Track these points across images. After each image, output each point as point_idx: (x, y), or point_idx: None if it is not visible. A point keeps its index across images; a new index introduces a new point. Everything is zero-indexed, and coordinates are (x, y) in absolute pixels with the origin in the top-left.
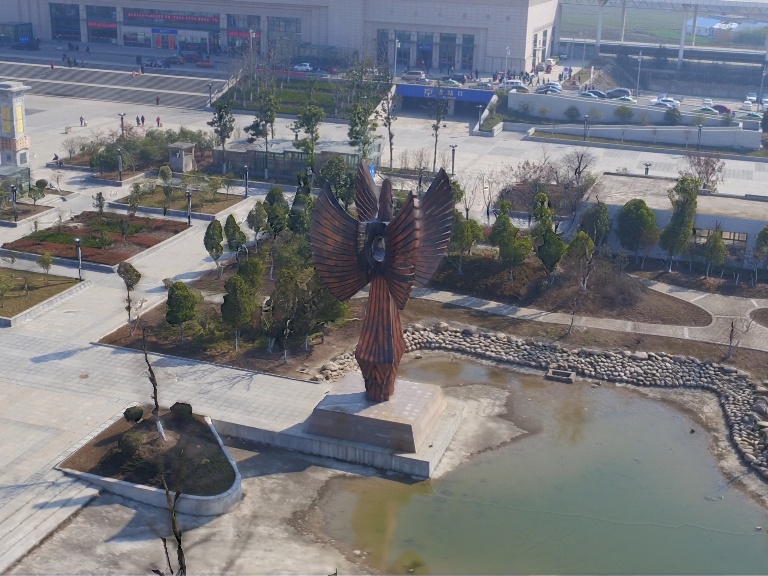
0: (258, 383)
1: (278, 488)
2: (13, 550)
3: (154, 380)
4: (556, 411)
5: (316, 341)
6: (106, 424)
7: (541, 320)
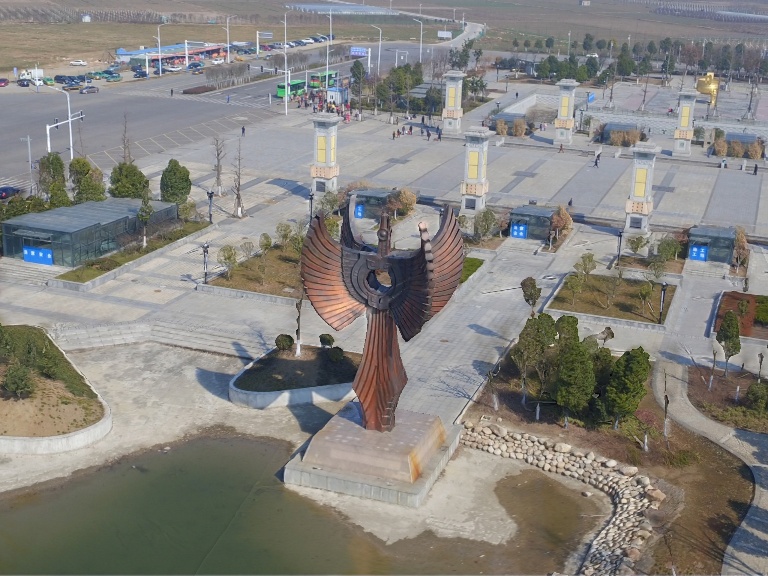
0: (447, 399)
1: (272, 421)
2: (185, 342)
3: (300, 307)
4: (450, 570)
5: (567, 424)
6: (355, 351)
7: (725, 570)
